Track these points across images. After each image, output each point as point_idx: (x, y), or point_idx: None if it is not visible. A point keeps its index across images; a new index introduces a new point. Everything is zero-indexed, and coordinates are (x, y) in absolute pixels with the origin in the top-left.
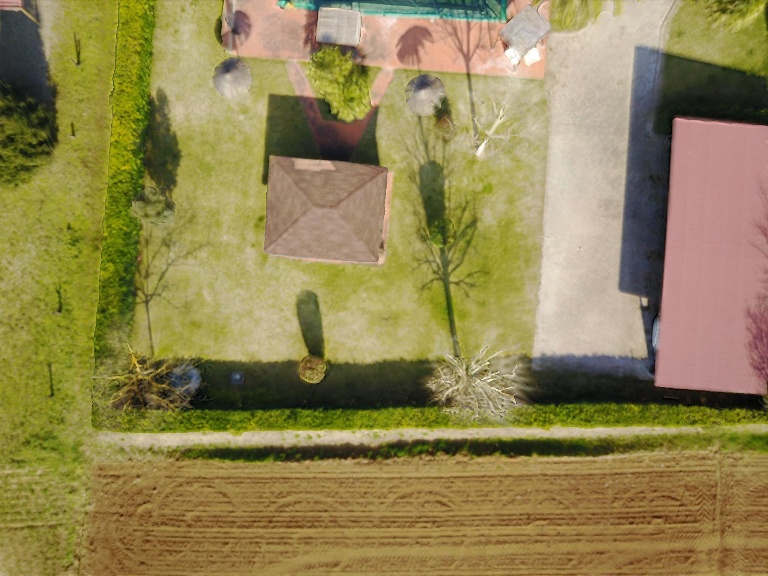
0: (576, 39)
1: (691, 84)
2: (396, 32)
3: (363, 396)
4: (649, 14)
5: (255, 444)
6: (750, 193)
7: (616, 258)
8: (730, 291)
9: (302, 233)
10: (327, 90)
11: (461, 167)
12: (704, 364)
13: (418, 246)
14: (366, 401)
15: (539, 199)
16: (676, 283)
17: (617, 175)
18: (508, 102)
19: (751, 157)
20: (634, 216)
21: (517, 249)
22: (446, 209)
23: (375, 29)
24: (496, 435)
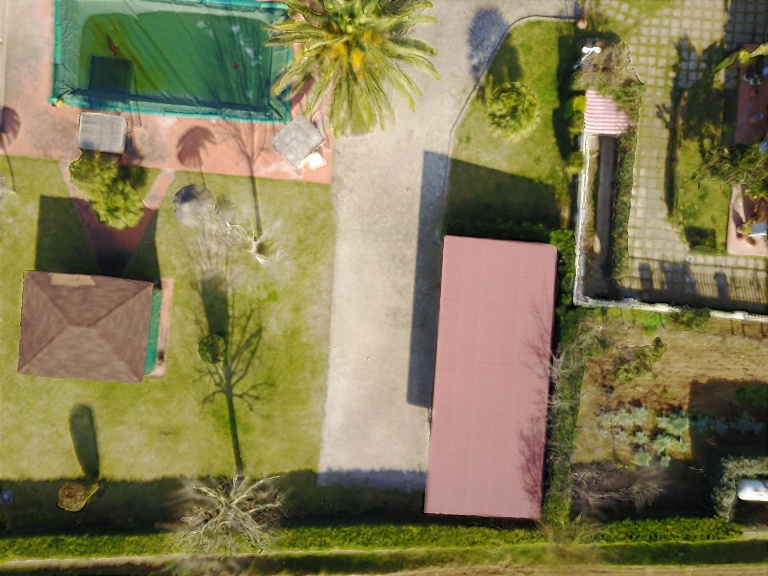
0: (365, 142)
1: (480, 190)
2: (177, 132)
3: (140, 516)
4: (439, 118)
5: (27, 567)
6: (524, 311)
7: (404, 369)
8: (503, 412)
9: (58, 353)
10: (91, 198)
11: (245, 274)
12: (476, 488)
13: (199, 357)
14: (143, 521)
15: (326, 307)
16: (447, 406)
17: (406, 283)
18: (295, 206)
19: (525, 274)
20: (423, 325)
21: (303, 360)
22: (230, 318)
23: (155, 129)
24: (283, 552)
